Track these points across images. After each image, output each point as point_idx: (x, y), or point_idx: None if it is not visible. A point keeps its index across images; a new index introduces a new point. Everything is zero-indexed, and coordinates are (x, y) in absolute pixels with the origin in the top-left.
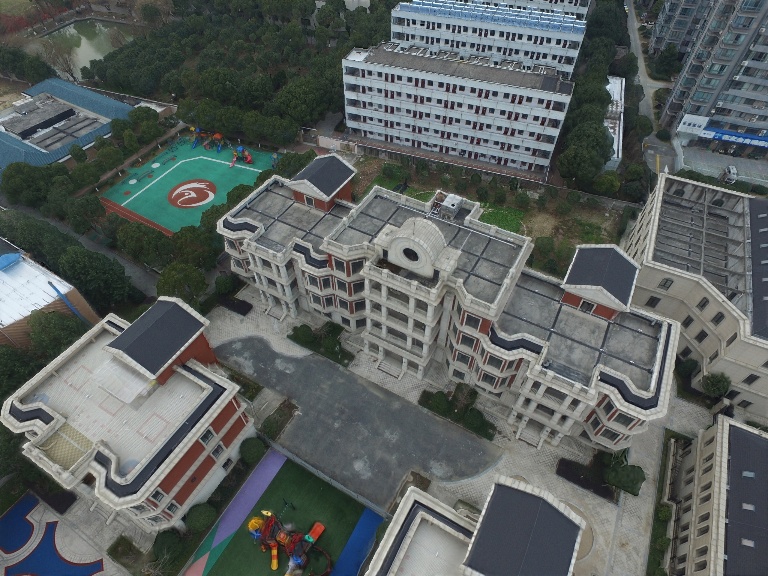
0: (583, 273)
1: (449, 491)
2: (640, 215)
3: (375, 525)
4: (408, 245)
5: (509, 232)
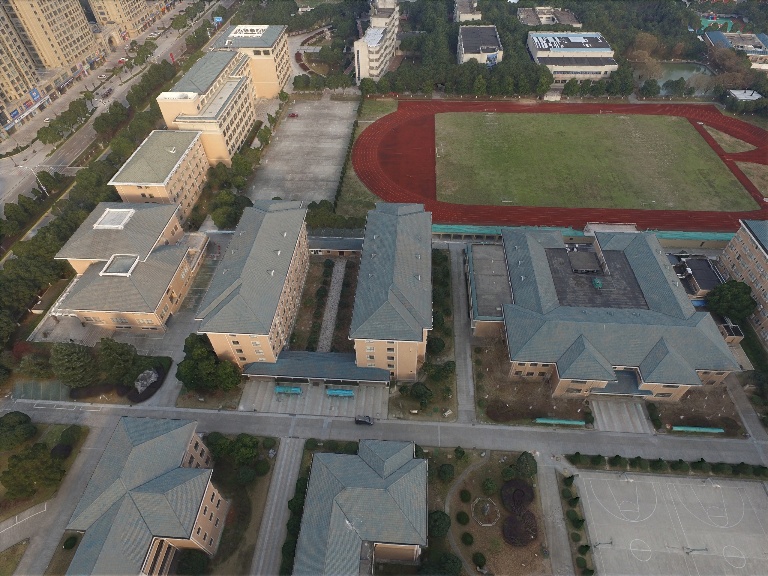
0: None
1: None
2: None
3: None
4: None
5: None
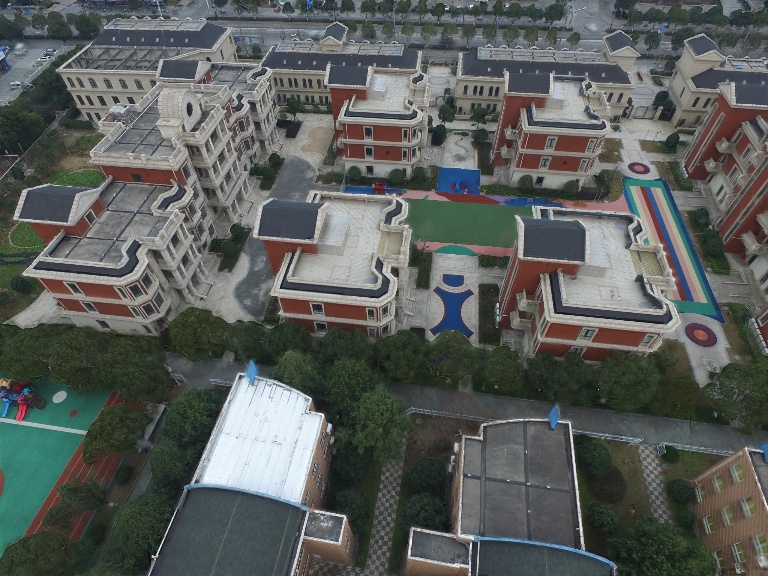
0: (185, 71)
1: None
2: (81, 106)
3: (351, 189)
4: None
5: (153, 89)
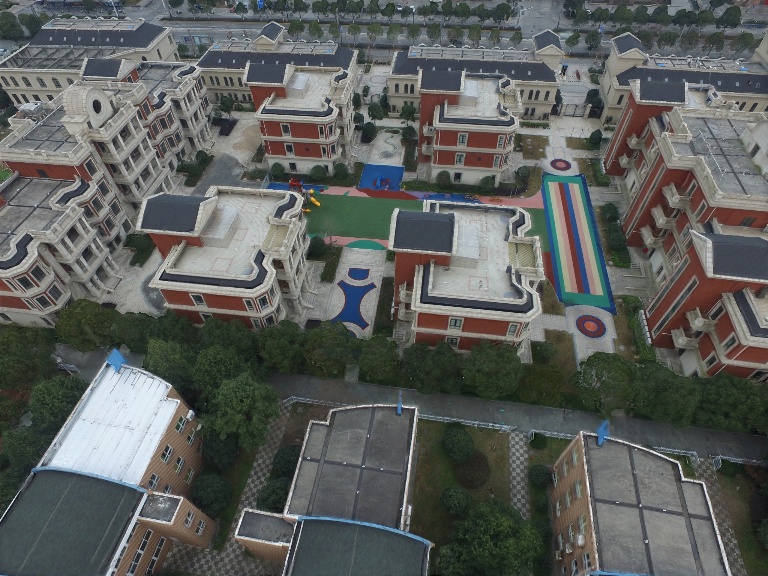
0: (108, 70)
1: (248, 166)
2: (18, 104)
3: (275, 185)
4: (91, 99)
5: None
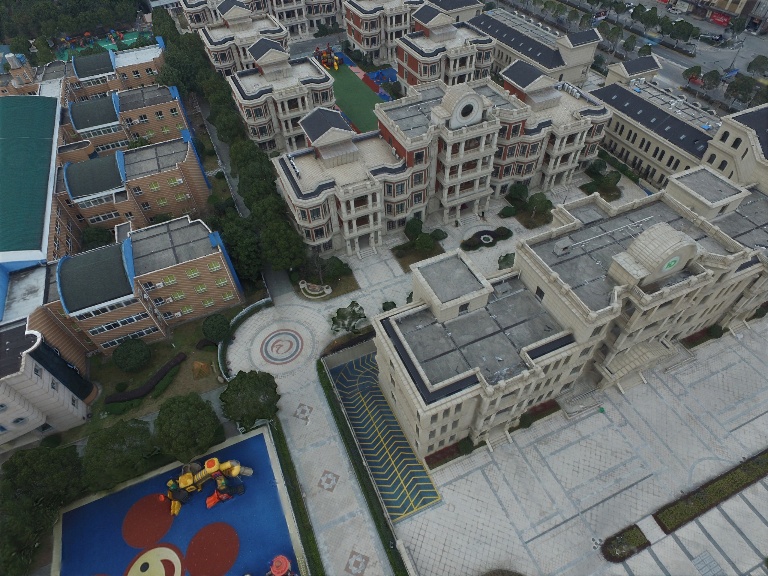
0: None
1: None
2: None
3: None
4: None
5: None
